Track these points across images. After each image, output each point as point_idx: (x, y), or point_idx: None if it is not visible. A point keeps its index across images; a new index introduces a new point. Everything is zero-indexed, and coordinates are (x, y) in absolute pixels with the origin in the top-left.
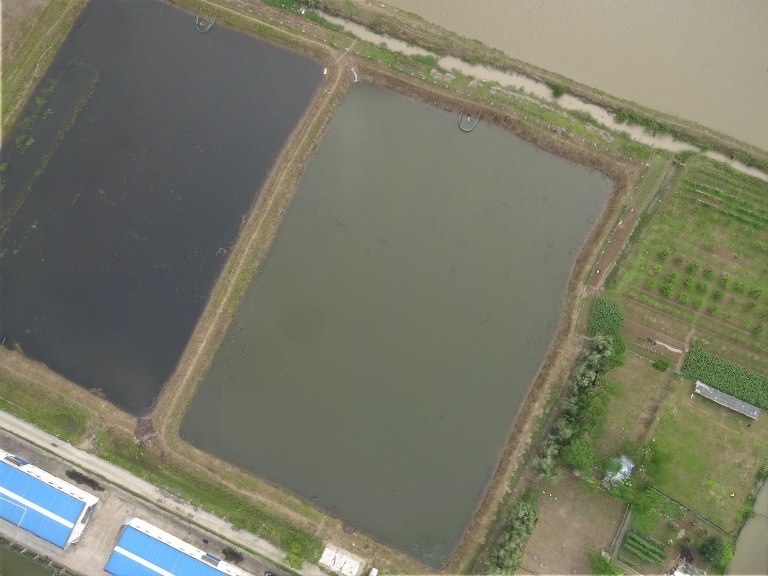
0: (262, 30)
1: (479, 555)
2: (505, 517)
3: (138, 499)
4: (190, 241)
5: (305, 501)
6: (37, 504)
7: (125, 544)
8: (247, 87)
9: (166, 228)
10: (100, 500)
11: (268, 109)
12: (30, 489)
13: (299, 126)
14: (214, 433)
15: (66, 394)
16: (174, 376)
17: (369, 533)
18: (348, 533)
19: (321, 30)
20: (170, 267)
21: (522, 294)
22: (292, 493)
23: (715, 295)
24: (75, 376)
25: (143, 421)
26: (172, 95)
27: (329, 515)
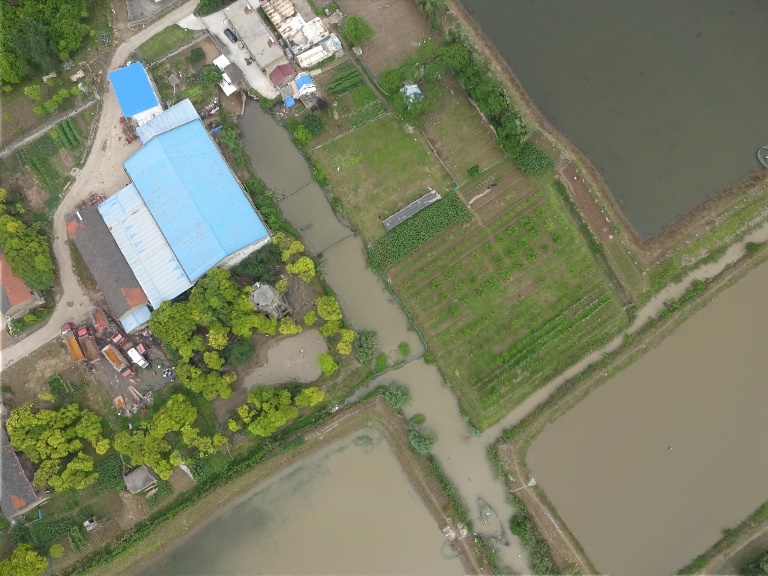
0: None
1: None
2: None
3: None
4: None
5: None
6: None
7: None
8: None
9: None
10: None
11: None
12: None
13: None
14: None
15: None
16: None
17: None
18: None
19: None
20: None
21: None
22: None
23: (500, 256)
24: None
25: None
26: None
27: None
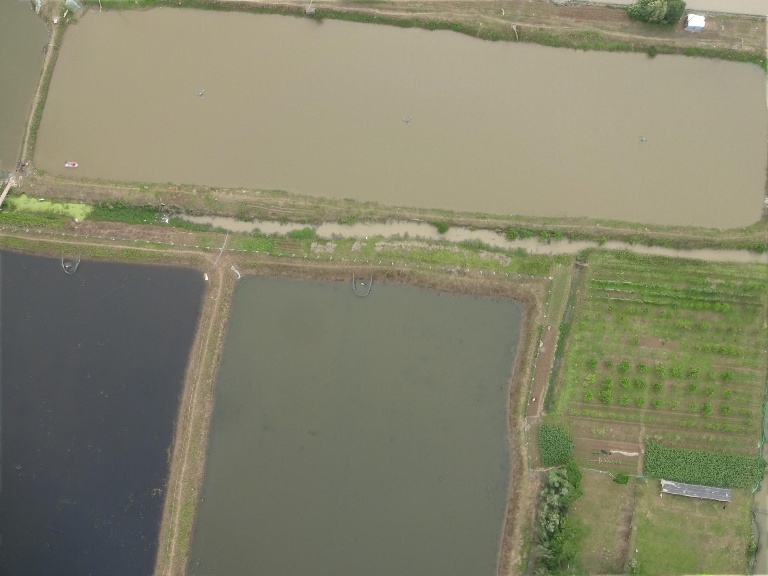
0: (130, 255)
1: None
2: None
3: None
4: (122, 491)
5: None
6: None
7: None
8: (133, 316)
9: (94, 485)
10: None
11: (160, 332)
12: None
13: (196, 341)
14: None
15: None
16: None
17: None
18: None
19: (190, 235)
20: (110, 524)
21: (466, 444)
22: None
23: (654, 388)
24: None
25: None
26: (60, 347)
27: None
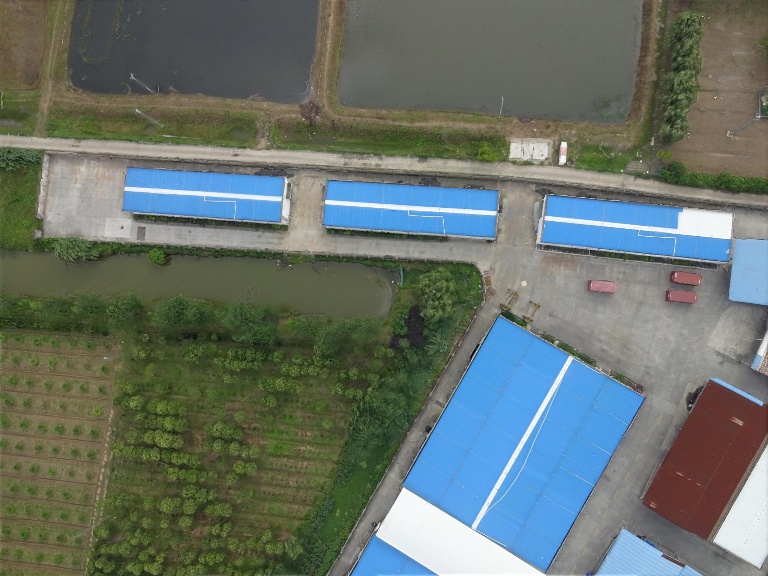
0: None
1: (656, 92)
2: (668, 43)
3: (327, 167)
4: None
5: (476, 113)
6: (243, 194)
7: (333, 196)
8: None
9: None
10: (294, 185)
11: None
12: (232, 184)
13: None
14: (371, 90)
15: (229, 107)
16: (316, 57)
17: (545, 117)
18: (526, 122)
19: None
20: None
21: None
22: (461, 111)
23: None
24: (230, 93)
25: (304, 105)
26: None
27: (502, 116)
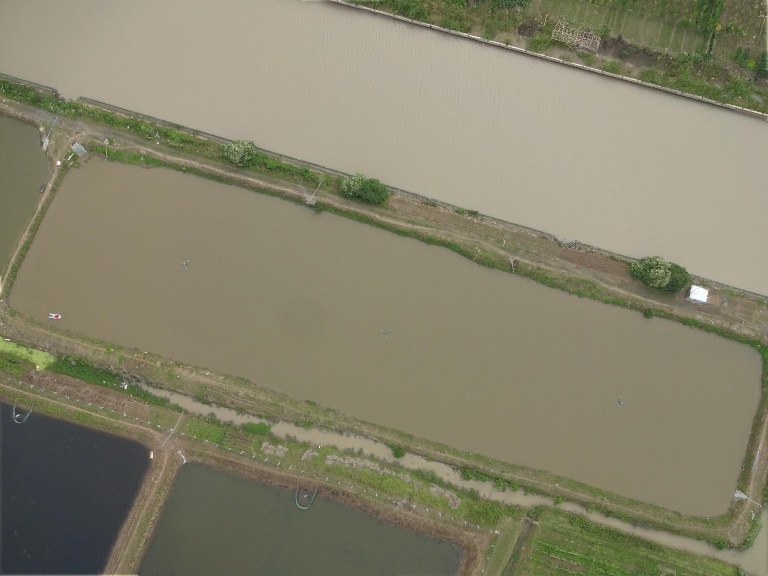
0: (81, 417)
1: None
2: None
3: None
4: None
5: None
6: None
7: None
8: (71, 480)
9: None
10: None
11: (95, 502)
12: None
13: (128, 519)
14: None
15: None
16: None
17: None
18: None
19: (145, 408)
20: None
21: None
22: None
23: None
24: None
25: None
26: None
27: None
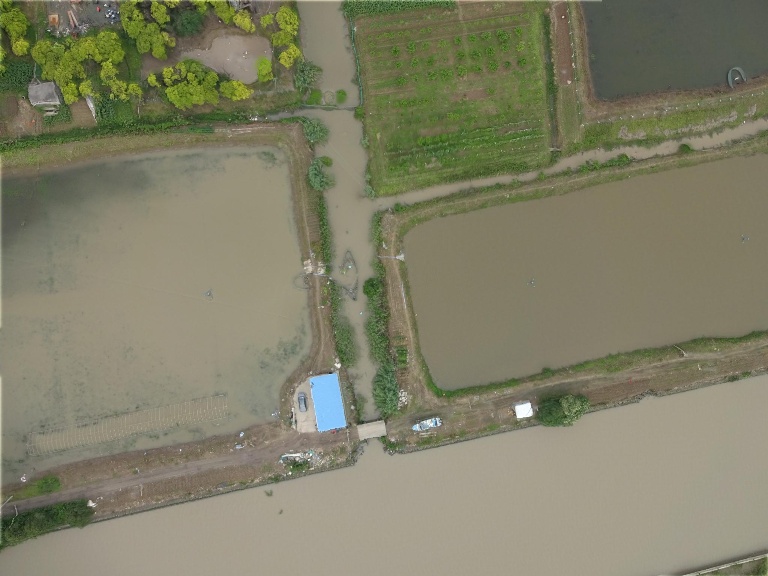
0: None
1: None
2: None
3: None
4: None
5: None
6: None
7: None
8: None
9: None
10: None
11: None
12: None
13: None
14: None
15: None
16: None
17: None
18: None
19: None
20: None
21: None
22: None
23: None
24: None
25: None
26: None
27: None
